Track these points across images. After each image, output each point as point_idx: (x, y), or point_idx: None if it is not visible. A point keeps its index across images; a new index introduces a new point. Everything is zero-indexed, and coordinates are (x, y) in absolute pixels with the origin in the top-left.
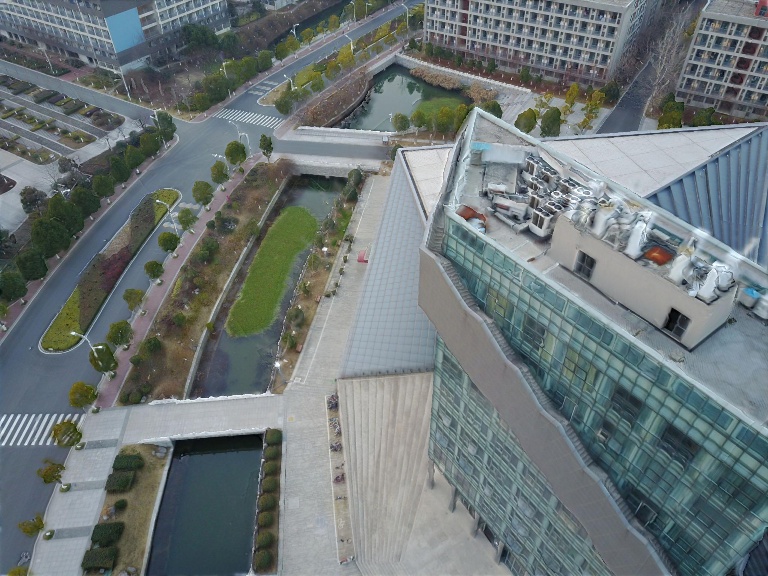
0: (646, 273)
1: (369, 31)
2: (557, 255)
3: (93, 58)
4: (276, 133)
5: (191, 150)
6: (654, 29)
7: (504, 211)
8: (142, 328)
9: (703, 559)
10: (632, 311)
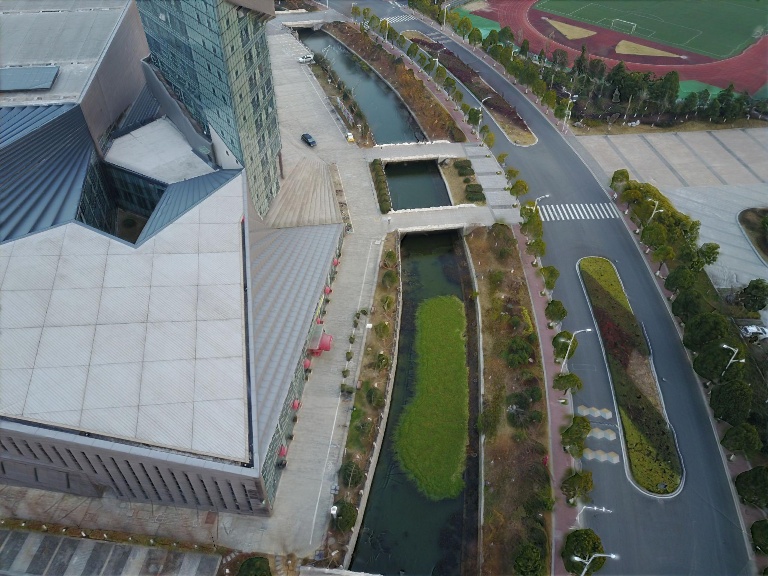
0: None
1: None
2: None
3: None
4: None
5: None
6: None
7: None
8: (533, 279)
9: None
10: None
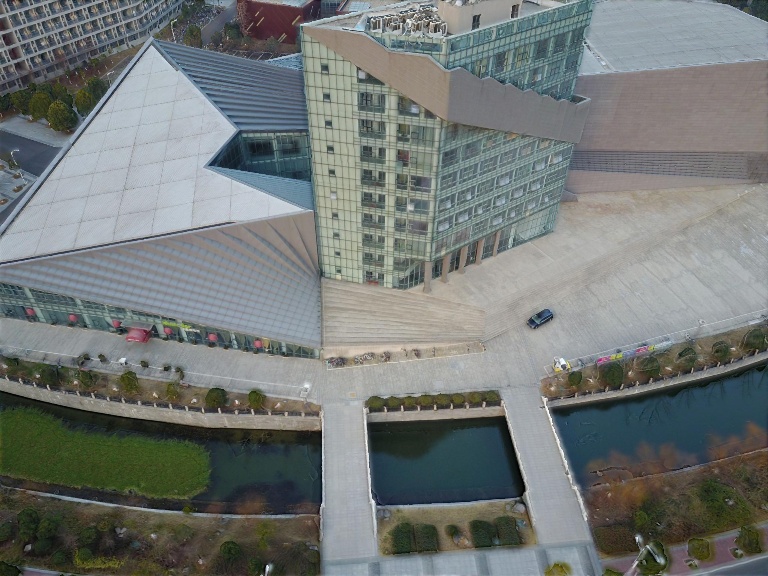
0: None
1: None
2: None
3: None
4: None
5: None
6: None
7: None
8: None
9: None
10: None
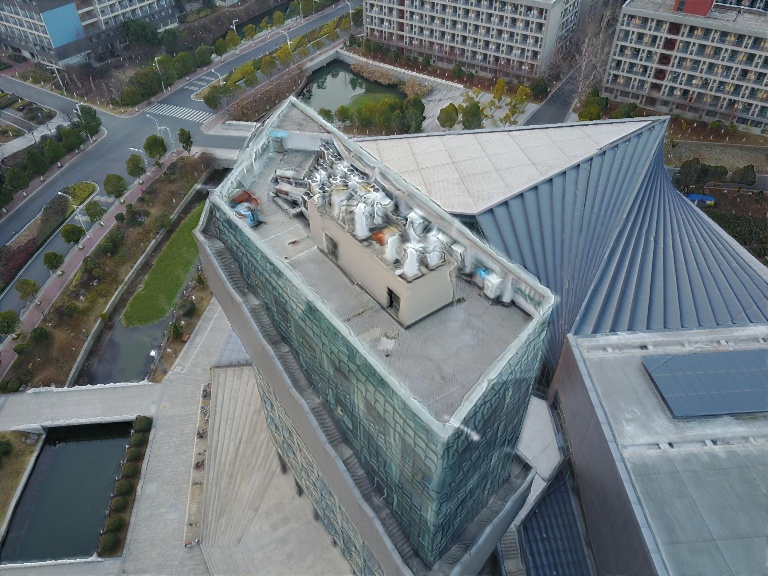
0: (365, 253)
1: (315, 27)
2: (315, 238)
3: (34, 53)
4: (204, 127)
5: (116, 144)
6: (595, 26)
7: (284, 196)
8: (35, 318)
9: (417, 531)
10: (366, 291)
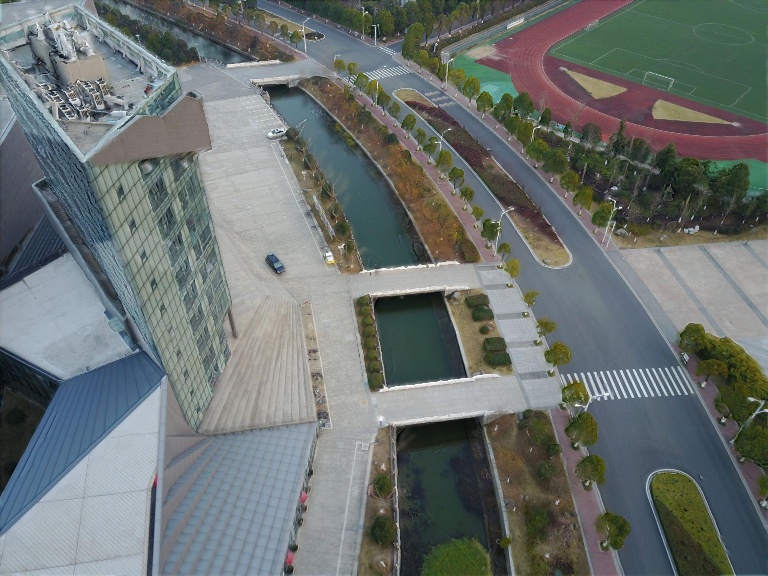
0: None
1: None
2: None
3: None
4: None
5: None
6: None
7: None
8: (587, 516)
9: None
10: None
